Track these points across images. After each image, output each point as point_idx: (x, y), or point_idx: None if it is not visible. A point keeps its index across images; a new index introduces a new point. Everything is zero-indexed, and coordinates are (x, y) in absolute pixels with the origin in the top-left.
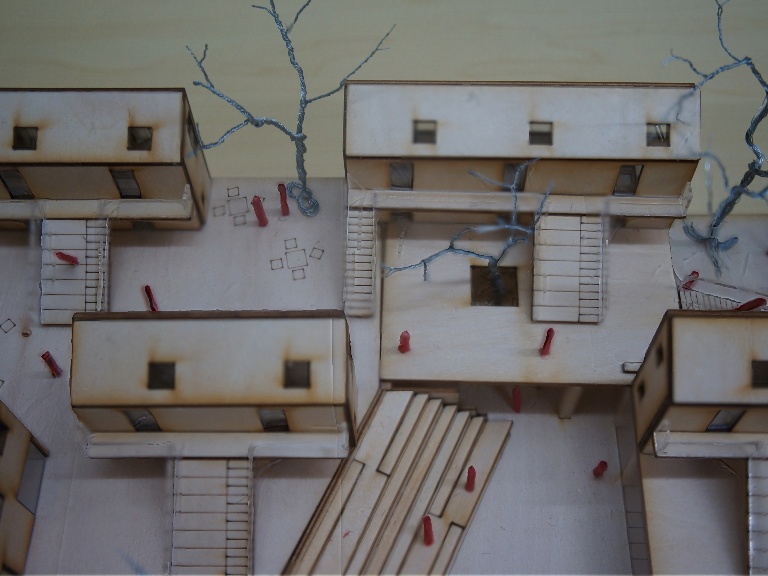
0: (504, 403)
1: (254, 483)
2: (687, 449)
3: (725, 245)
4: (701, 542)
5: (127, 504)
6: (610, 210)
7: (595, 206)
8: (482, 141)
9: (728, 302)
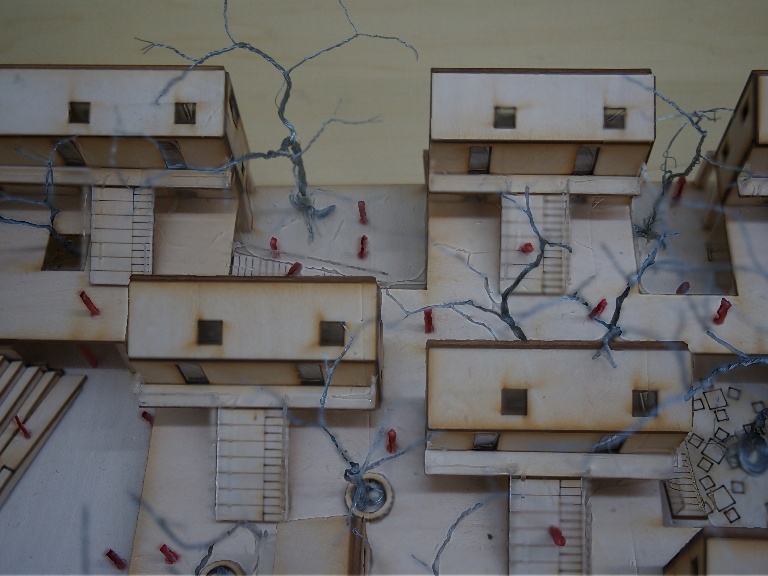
0: (85, 359)
1: None
2: (165, 399)
3: (322, 213)
4: (189, 482)
5: None
6: (159, 182)
7: (149, 178)
8: (26, 120)
9: (288, 266)
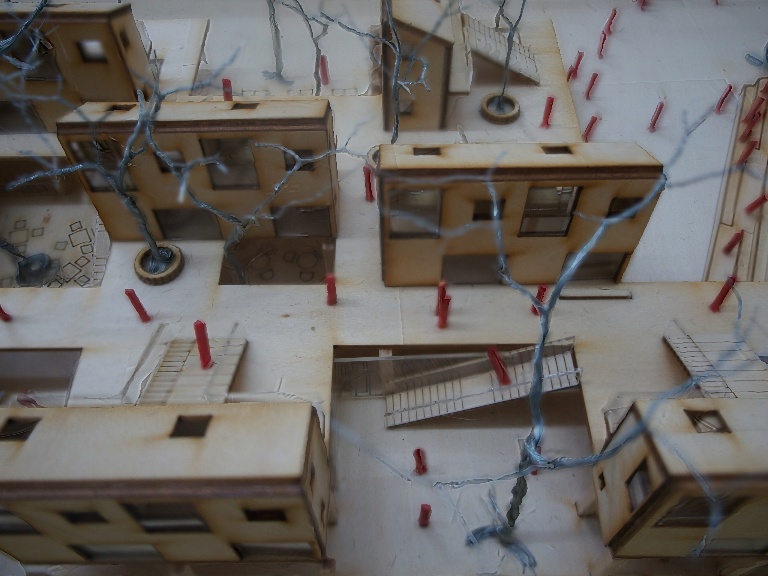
0: None
1: None
2: None
3: (484, 531)
4: None
5: None
6: None
7: None
8: None
9: (508, 398)
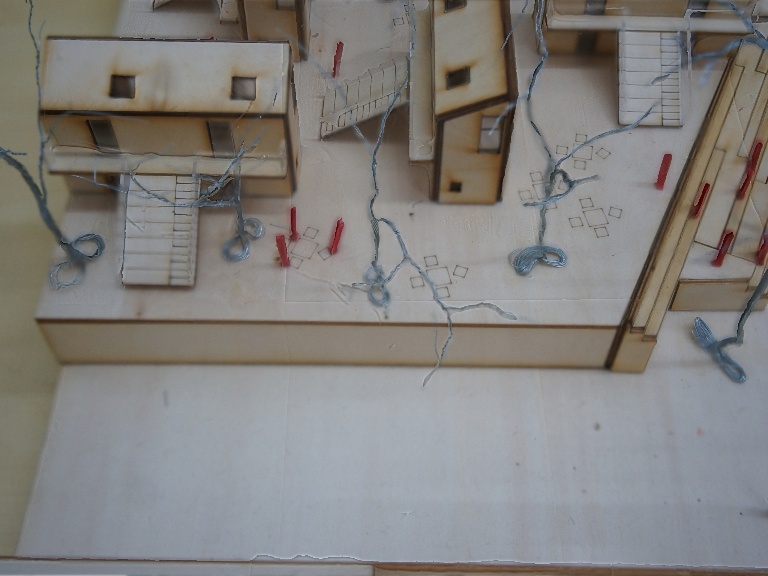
0: None
1: (681, 51)
2: None
3: None
4: None
5: (565, 82)
6: None
7: None
8: None
9: None
